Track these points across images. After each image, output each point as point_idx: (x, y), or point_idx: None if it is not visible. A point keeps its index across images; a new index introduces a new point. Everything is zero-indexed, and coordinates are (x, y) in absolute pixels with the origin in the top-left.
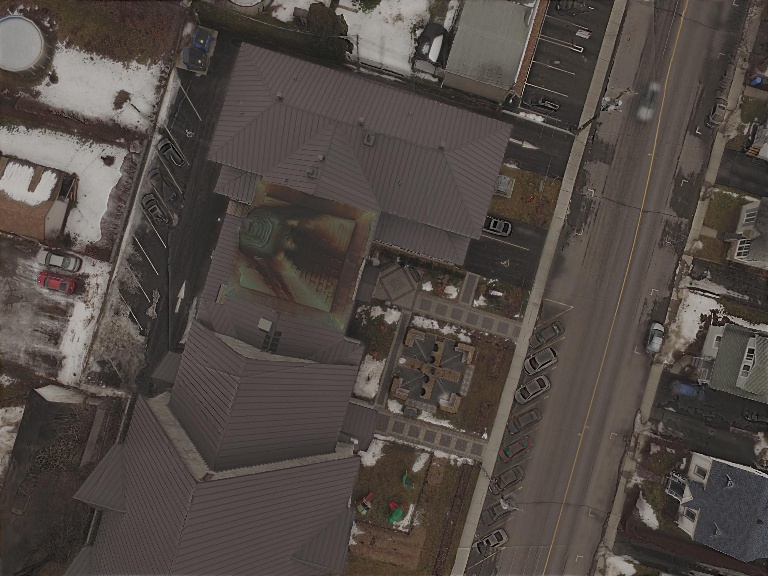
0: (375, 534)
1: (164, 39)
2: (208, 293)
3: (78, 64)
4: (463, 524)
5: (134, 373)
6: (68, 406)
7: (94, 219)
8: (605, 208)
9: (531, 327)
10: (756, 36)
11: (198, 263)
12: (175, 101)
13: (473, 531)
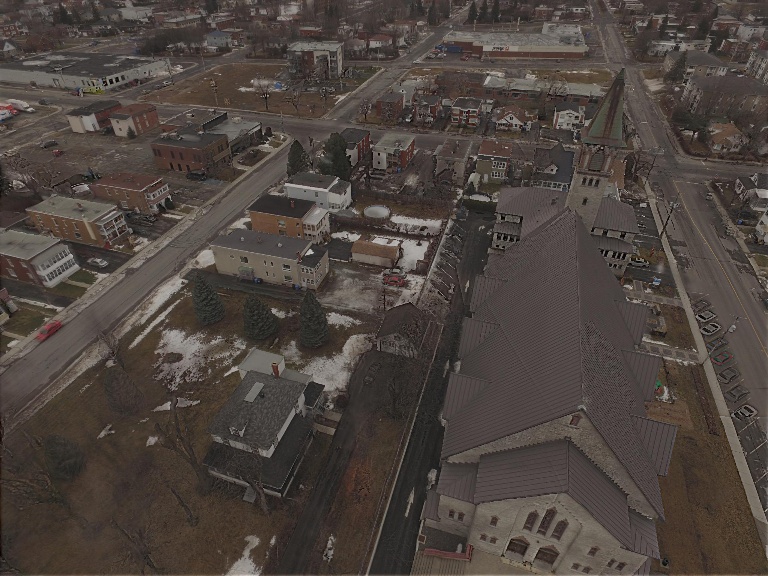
0: (646, 403)
1: None
2: None
3: (402, 219)
4: (713, 400)
5: (444, 315)
6: (418, 309)
7: (412, 262)
8: (696, 260)
9: (688, 302)
10: (727, 213)
11: (475, 274)
12: (452, 227)
13: (724, 405)
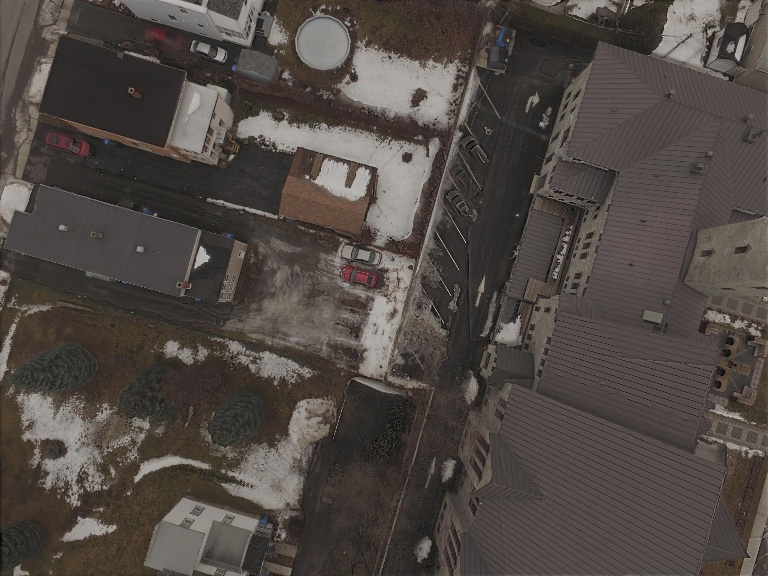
0: None
1: (460, 38)
2: (516, 287)
3: (377, 63)
4: (754, 515)
5: (437, 365)
6: (396, 397)
7: (393, 215)
8: None
9: None
10: None
11: (497, 258)
12: (475, 99)
13: (764, 522)
